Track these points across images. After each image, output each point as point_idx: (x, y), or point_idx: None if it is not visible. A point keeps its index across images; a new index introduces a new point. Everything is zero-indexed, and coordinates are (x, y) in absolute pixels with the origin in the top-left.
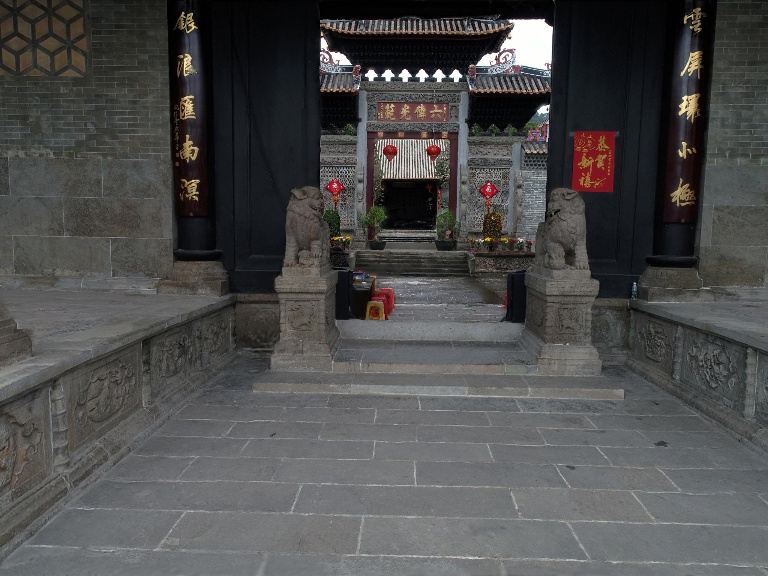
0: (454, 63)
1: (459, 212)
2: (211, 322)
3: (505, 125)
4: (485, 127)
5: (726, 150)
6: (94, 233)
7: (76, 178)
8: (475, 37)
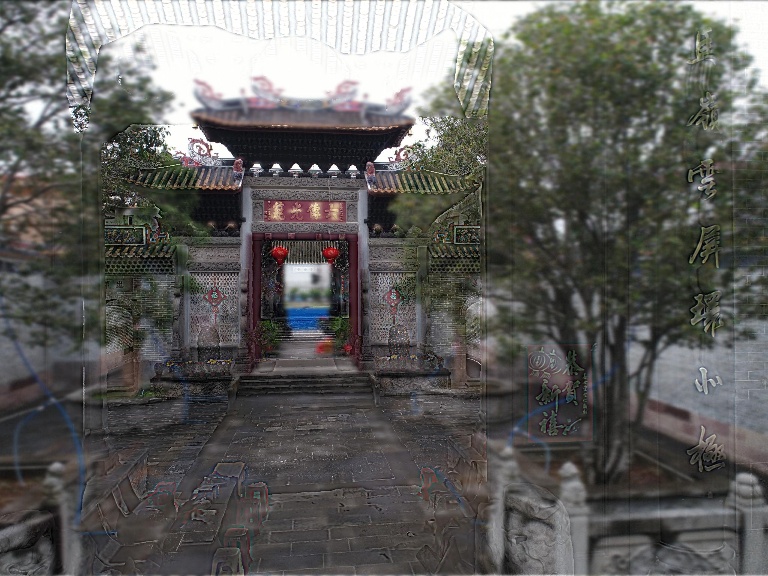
0: (350, 158)
1: (361, 323)
2: None
3: (409, 226)
4: (387, 228)
5: (762, 375)
6: None
7: None
8: (372, 132)
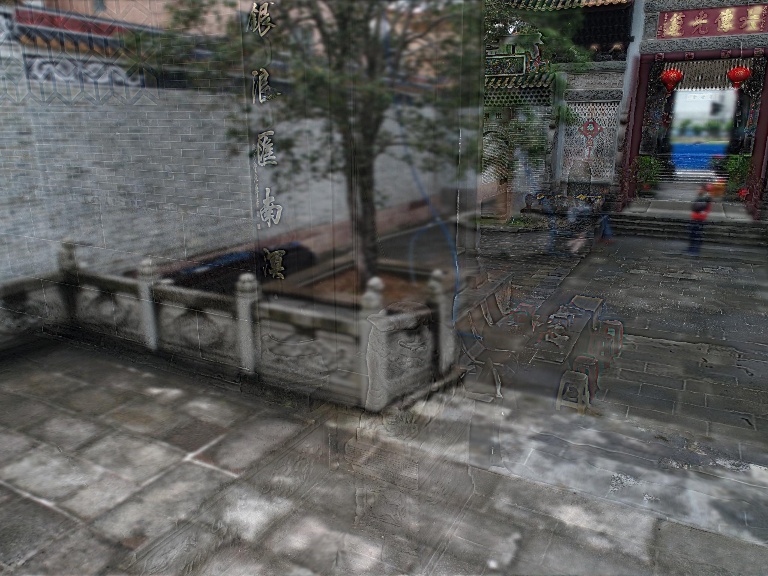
0: None
1: (767, 163)
2: (280, 464)
3: None
4: None
5: None
6: (181, 302)
7: (160, 234)
8: None
